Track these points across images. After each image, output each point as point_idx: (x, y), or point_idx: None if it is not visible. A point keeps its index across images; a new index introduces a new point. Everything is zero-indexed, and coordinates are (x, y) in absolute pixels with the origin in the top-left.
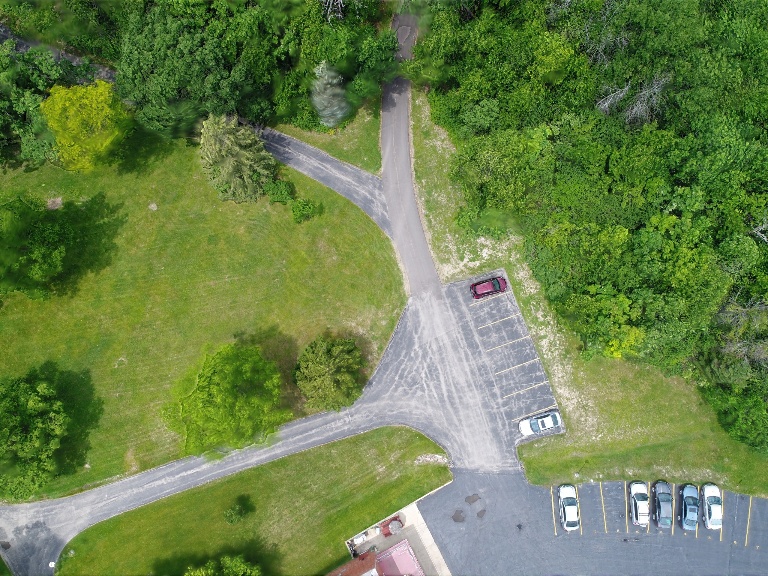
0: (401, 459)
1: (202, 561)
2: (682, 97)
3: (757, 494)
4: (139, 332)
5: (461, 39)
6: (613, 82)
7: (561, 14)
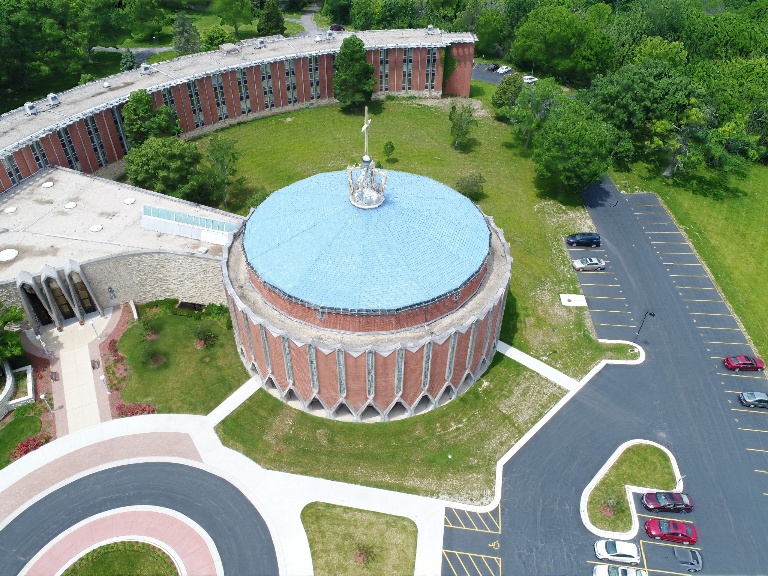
0: None
1: None
2: None
3: None
4: None
5: None
6: None
7: None
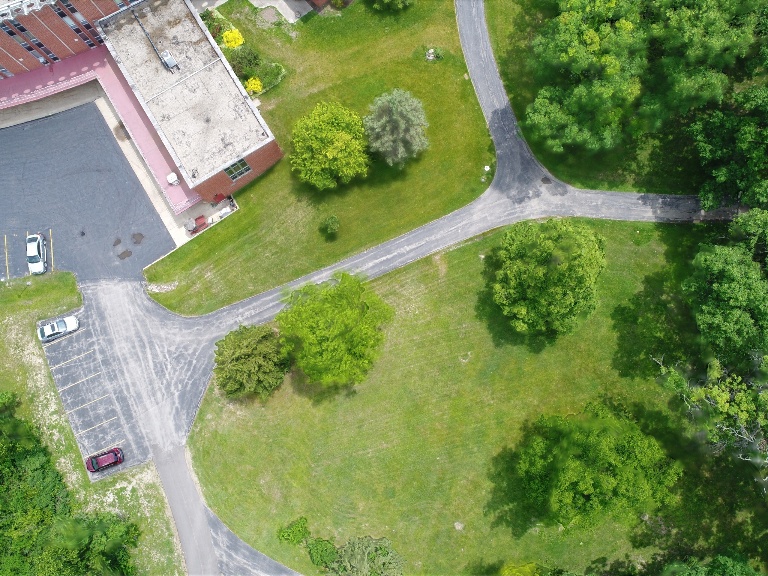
0: (190, 285)
1: (363, 182)
2: None
3: None
4: (452, 389)
5: None
6: None
7: None
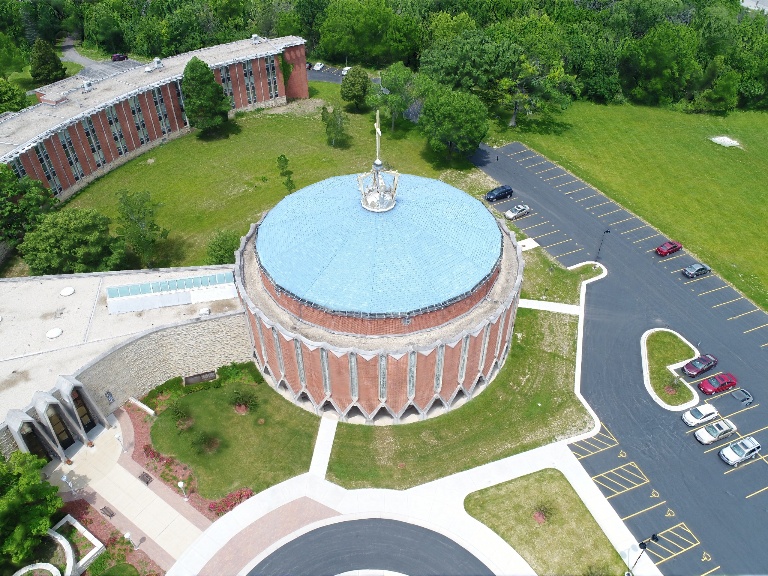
0: None
1: None
2: None
3: None
4: None
5: (78, 5)
6: (142, 7)
7: None
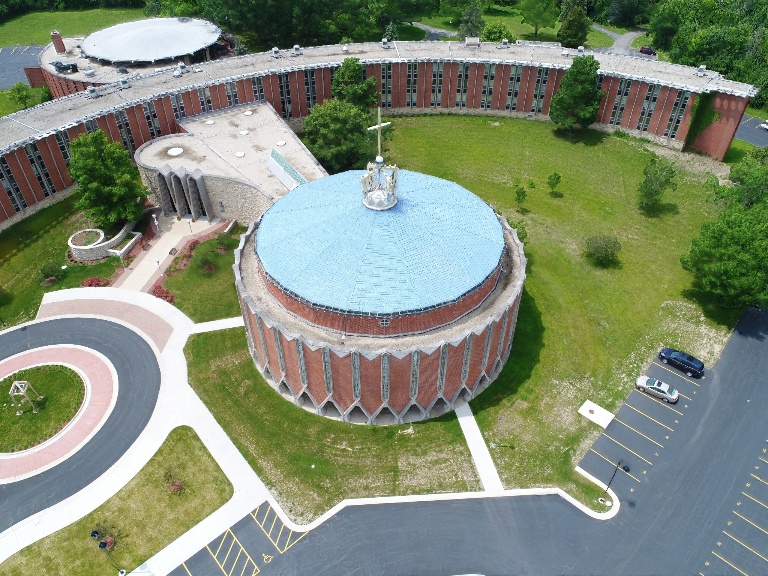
0: None
1: None
2: (754, 7)
3: (744, 113)
4: (509, 24)
5: None
6: None
7: (717, 0)
